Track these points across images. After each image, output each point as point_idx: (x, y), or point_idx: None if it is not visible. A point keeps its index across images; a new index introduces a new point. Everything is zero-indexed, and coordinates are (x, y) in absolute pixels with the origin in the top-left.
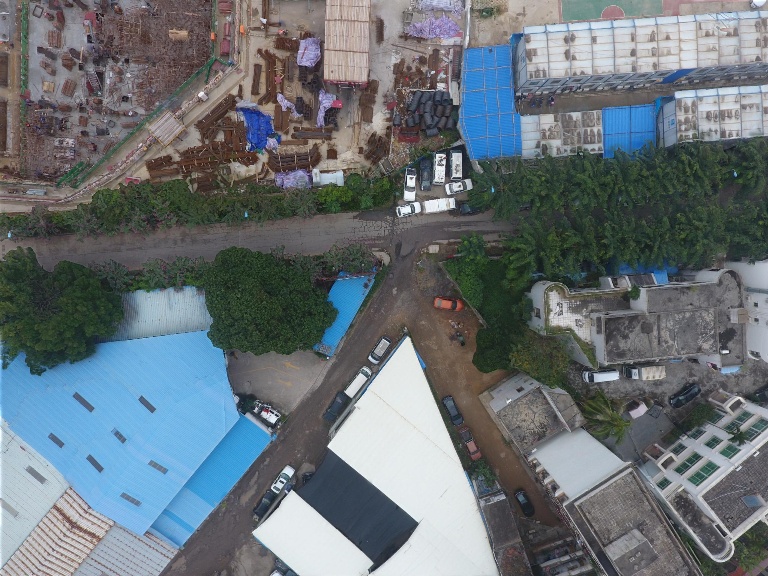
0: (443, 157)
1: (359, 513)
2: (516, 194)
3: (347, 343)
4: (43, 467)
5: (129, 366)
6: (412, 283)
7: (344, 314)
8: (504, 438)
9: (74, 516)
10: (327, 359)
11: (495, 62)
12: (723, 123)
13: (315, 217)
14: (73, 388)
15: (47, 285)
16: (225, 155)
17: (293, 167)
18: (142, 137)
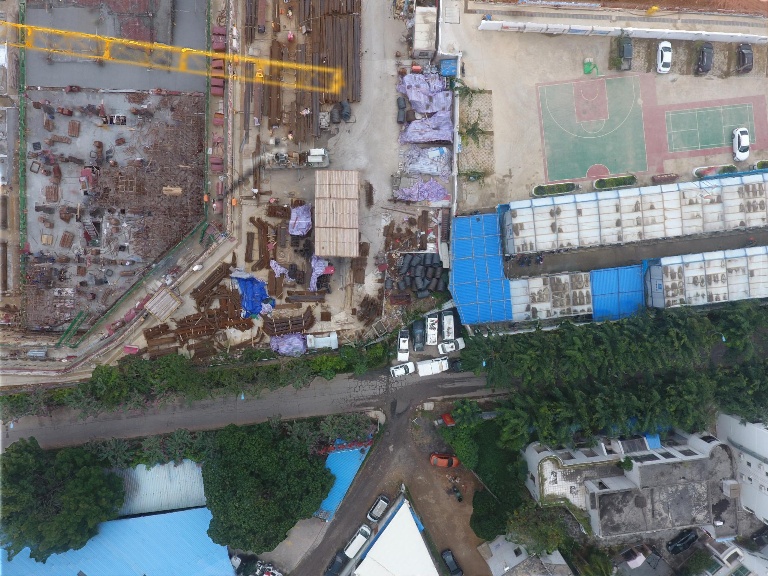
0: (435, 321)
1: None
2: (507, 367)
3: (346, 501)
4: None
5: (132, 544)
6: (408, 440)
7: (342, 479)
8: None
9: None
10: (326, 521)
11: (483, 231)
12: (710, 287)
13: None
14: (77, 567)
15: (49, 476)
16: (221, 323)
17: (288, 332)
18: (139, 295)
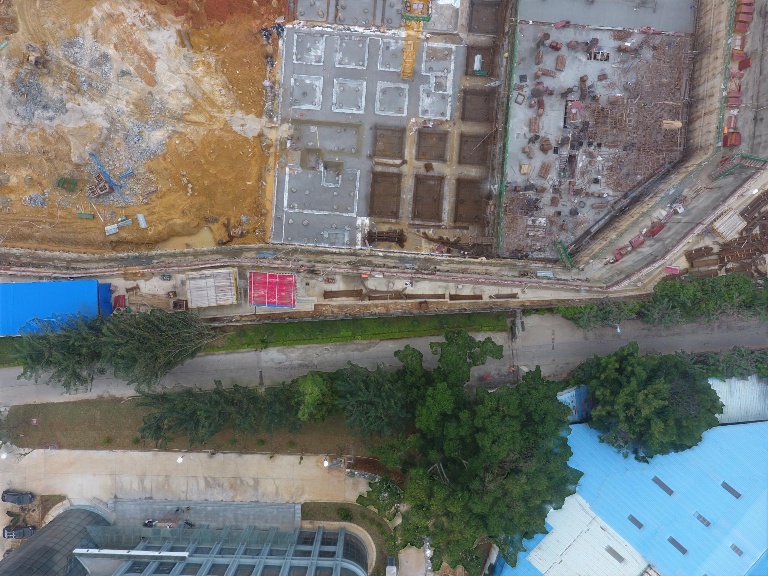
0: None
1: None
2: None
3: None
4: (622, 547)
5: (709, 452)
6: None
7: None
8: None
9: None
10: None
11: None
12: None
13: None
14: (652, 472)
15: None
16: (767, 247)
17: None
18: (644, 222)
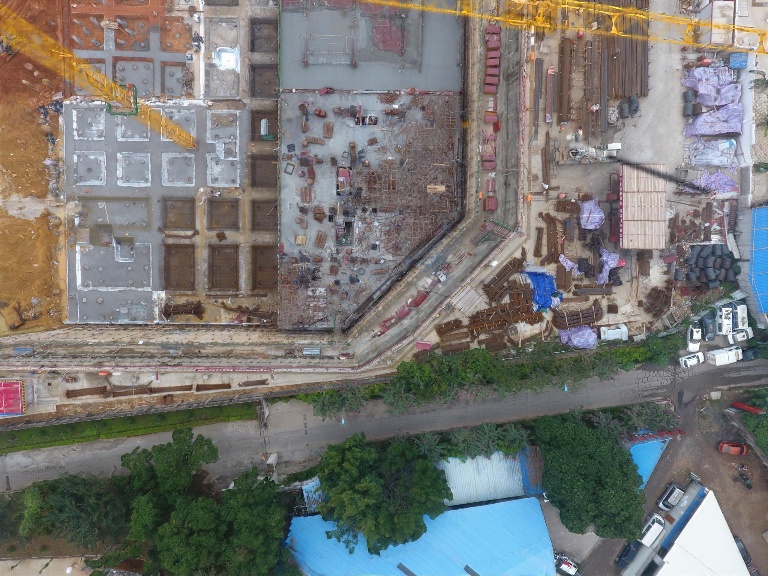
0: (730, 311)
1: None
2: None
3: None
4: None
5: (452, 536)
6: (695, 429)
7: (643, 469)
8: None
9: None
10: None
11: None
12: None
13: None
14: (397, 559)
15: (385, 470)
16: (515, 318)
17: (579, 325)
18: (410, 292)
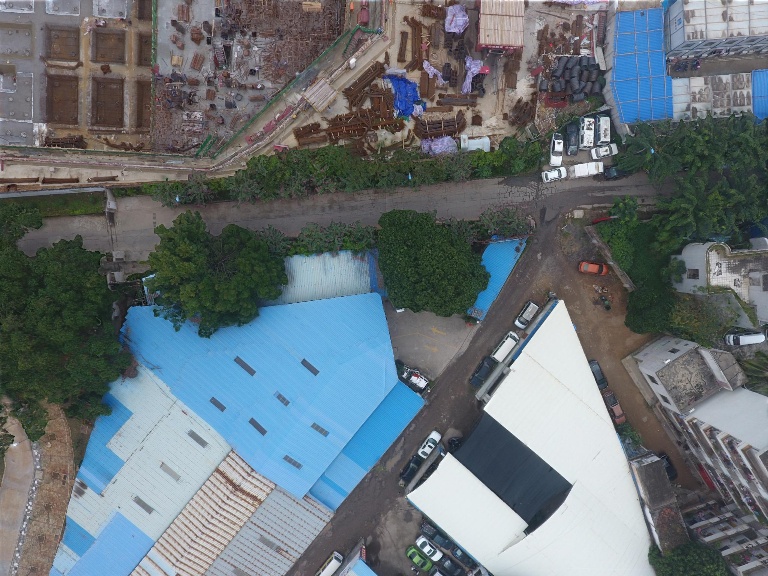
0: (592, 121)
1: (512, 476)
2: (676, 155)
3: (492, 308)
4: (205, 431)
5: (290, 330)
6: (556, 248)
7: (496, 278)
8: (646, 402)
9: (237, 479)
10: (476, 324)
11: (647, 25)
12: None
13: (462, 183)
14: (234, 352)
15: (217, 248)
16: (374, 122)
17: (440, 133)
18: (279, 108)
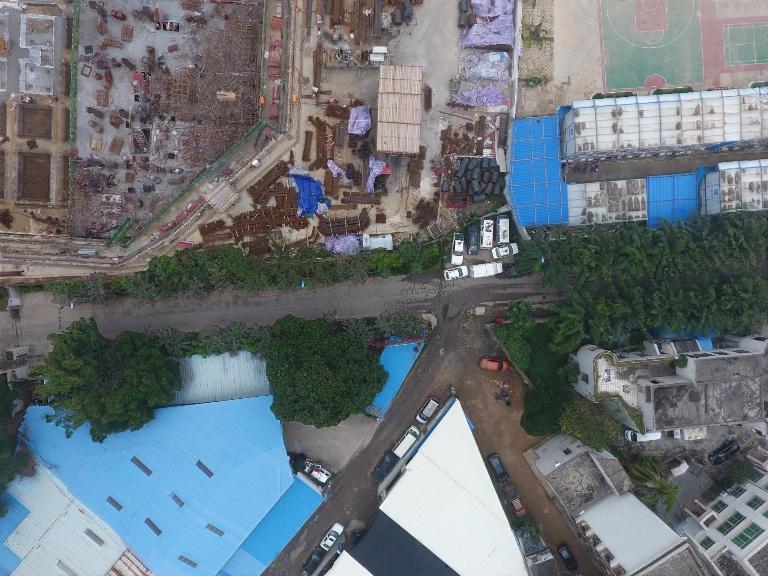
0: (491, 223)
1: (409, 572)
2: (565, 264)
3: (395, 403)
4: (101, 530)
5: (186, 431)
6: (459, 344)
7: (394, 377)
8: (548, 494)
9: None
10: (377, 420)
11: (543, 132)
12: (765, 193)
13: None
14: (131, 452)
15: (109, 355)
16: (277, 220)
17: (343, 232)
18: (191, 197)
